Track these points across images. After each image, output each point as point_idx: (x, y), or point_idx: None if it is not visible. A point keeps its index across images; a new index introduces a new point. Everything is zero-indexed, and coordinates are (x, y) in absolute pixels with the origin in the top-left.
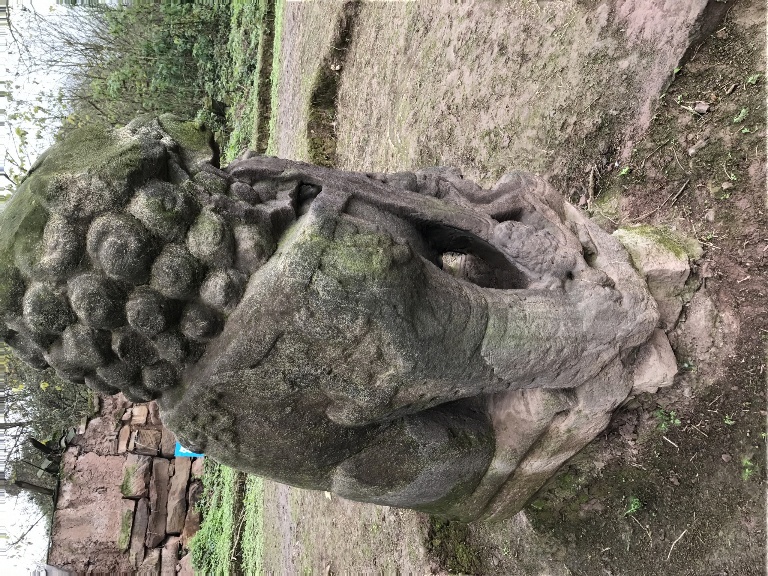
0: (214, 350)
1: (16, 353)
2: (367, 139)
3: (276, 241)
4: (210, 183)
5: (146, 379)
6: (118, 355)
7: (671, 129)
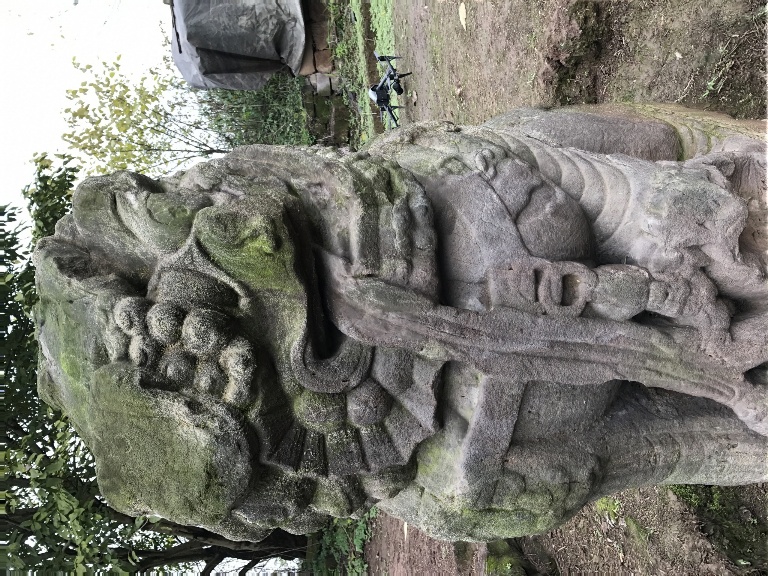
0: None
1: None
2: None
3: (415, 454)
4: (320, 427)
5: None
6: None
7: None
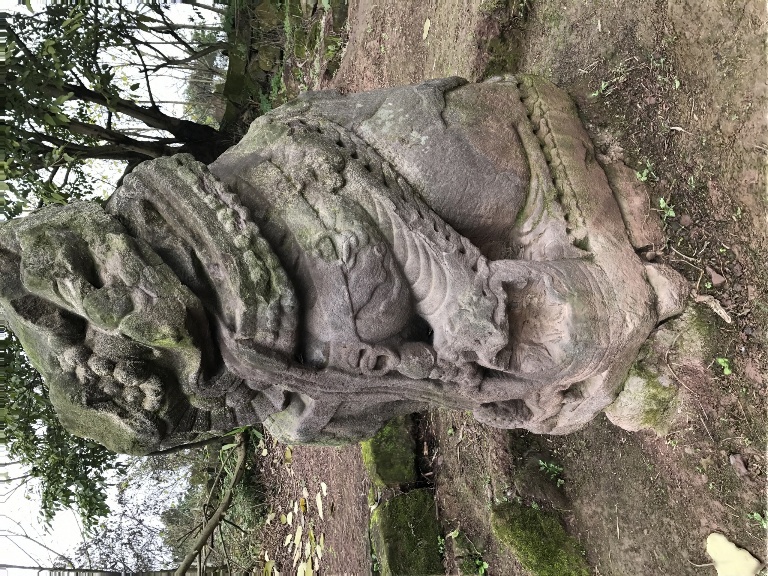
0: None
1: None
2: None
3: None
4: (207, 410)
5: None
6: None
7: (763, 443)
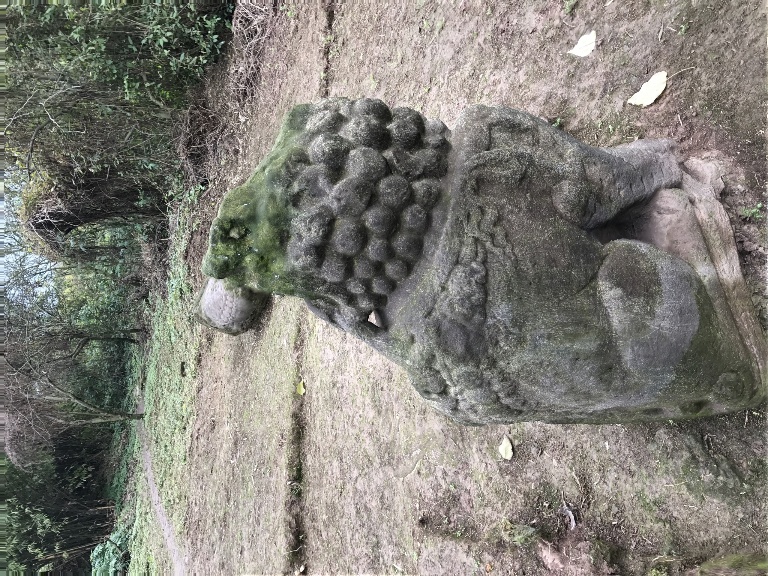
0: (454, 156)
1: (303, 217)
2: (377, 541)
3: None
4: None
5: (419, 188)
6: (392, 167)
7: None
